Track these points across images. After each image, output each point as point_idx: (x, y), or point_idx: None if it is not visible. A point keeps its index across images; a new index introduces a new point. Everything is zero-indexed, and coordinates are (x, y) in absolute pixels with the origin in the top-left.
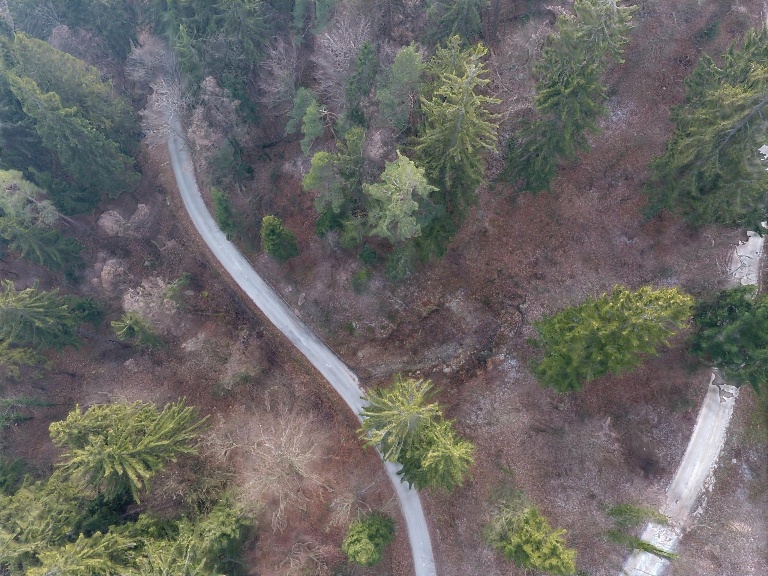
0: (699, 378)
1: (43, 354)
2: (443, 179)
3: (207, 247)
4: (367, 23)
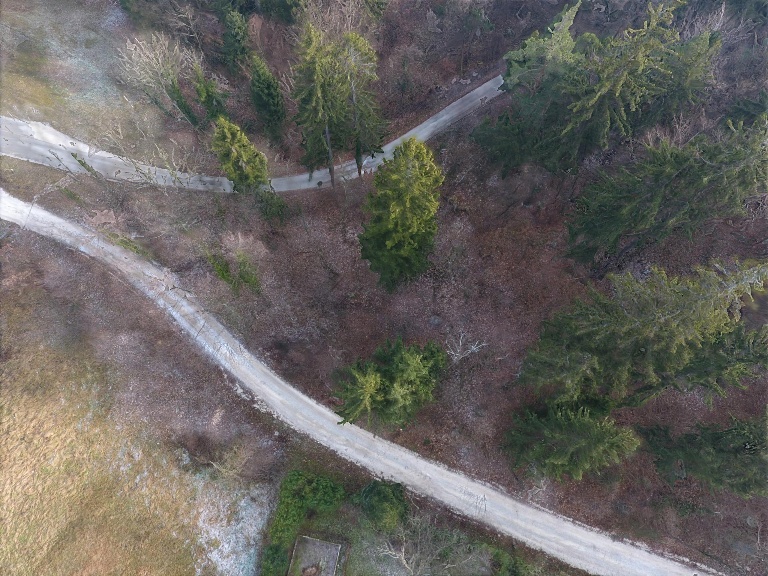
0: None
1: None
2: None
3: None
4: None
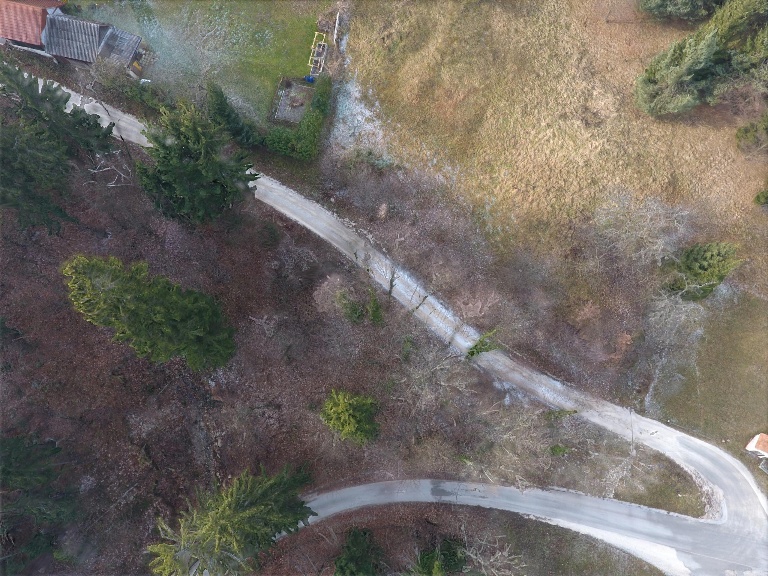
0: None
1: None
2: None
3: None
4: None
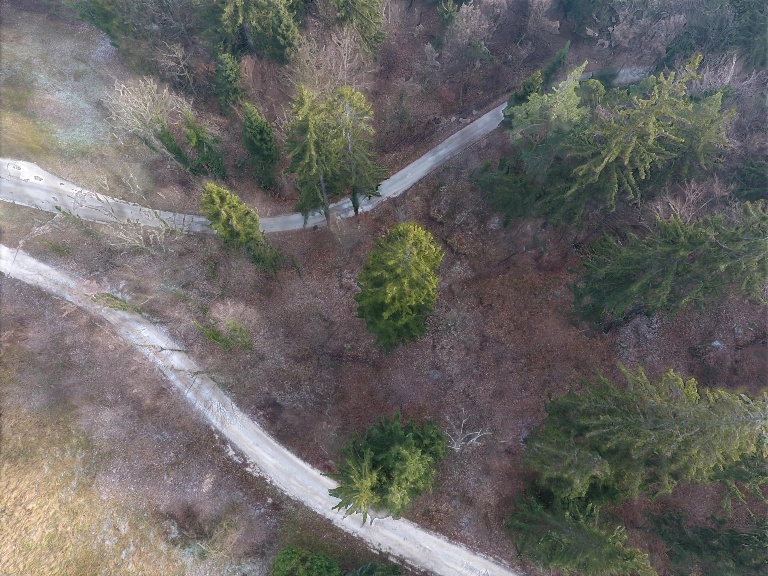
0: None
1: (437, 5)
2: None
3: None
4: (758, 91)
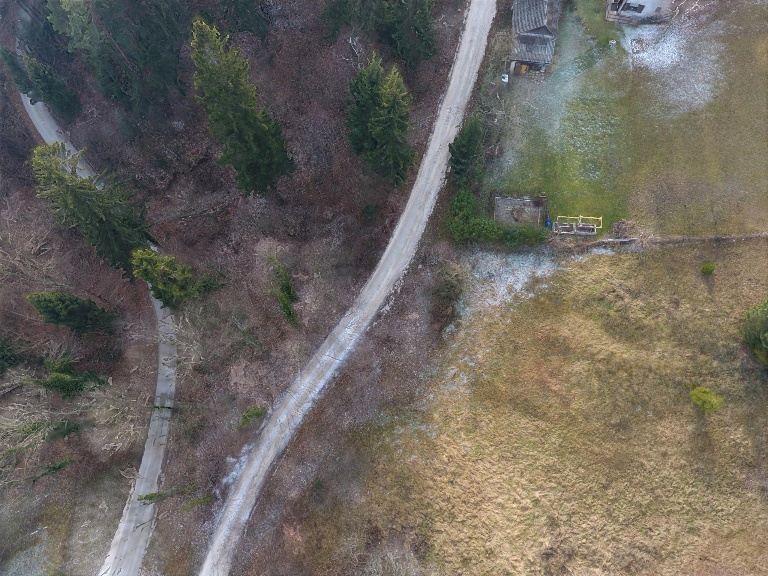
0: (396, 197)
1: None
2: (141, 2)
3: (31, 123)
4: None
